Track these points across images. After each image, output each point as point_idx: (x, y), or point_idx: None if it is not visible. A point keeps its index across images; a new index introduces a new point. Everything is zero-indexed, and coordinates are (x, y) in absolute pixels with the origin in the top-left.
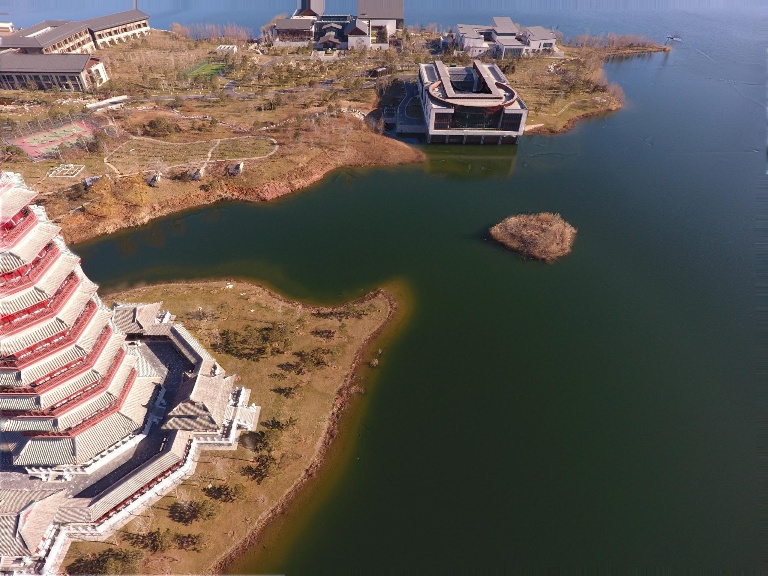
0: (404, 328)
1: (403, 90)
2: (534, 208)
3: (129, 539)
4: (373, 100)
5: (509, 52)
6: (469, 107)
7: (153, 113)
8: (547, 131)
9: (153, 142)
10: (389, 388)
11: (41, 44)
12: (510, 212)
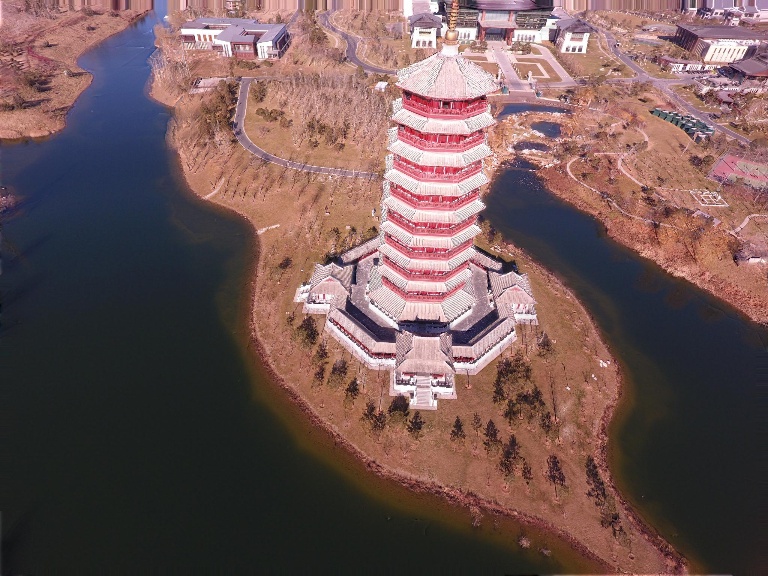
0: None
1: None
2: None
3: None
4: None
5: None
6: None
7: None
8: None
9: None
10: (491, 566)
11: None
12: None
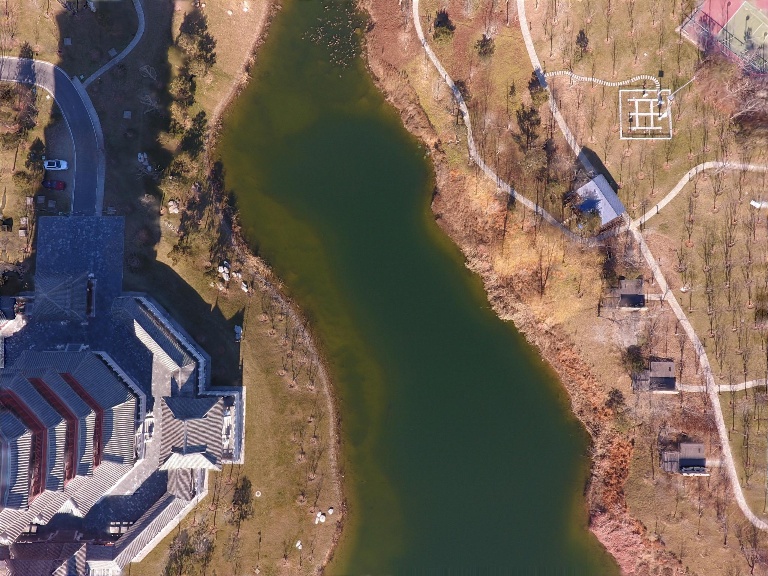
0: None
1: None
2: None
3: None
4: None
5: None
6: None
7: None
8: None
9: None
10: None
11: None
12: None
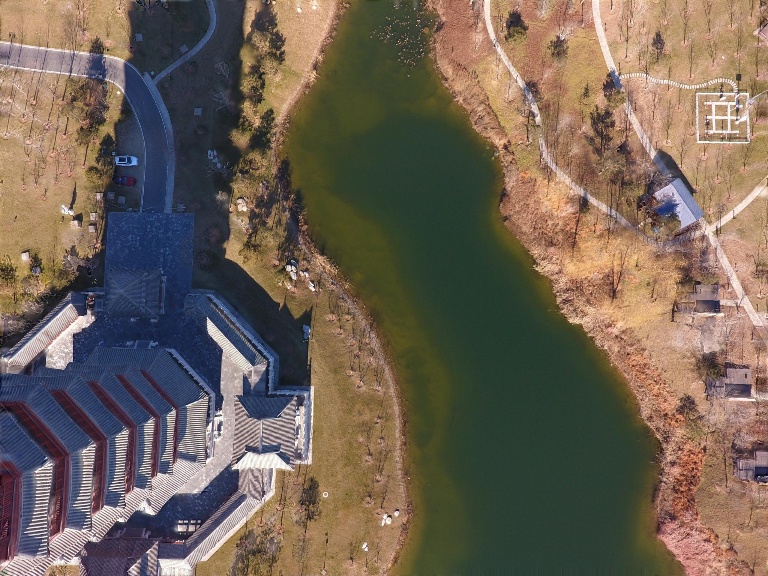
0: None
1: None
2: None
3: None
4: None
5: None
6: None
7: None
8: None
9: None
10: None
11: None
12: None
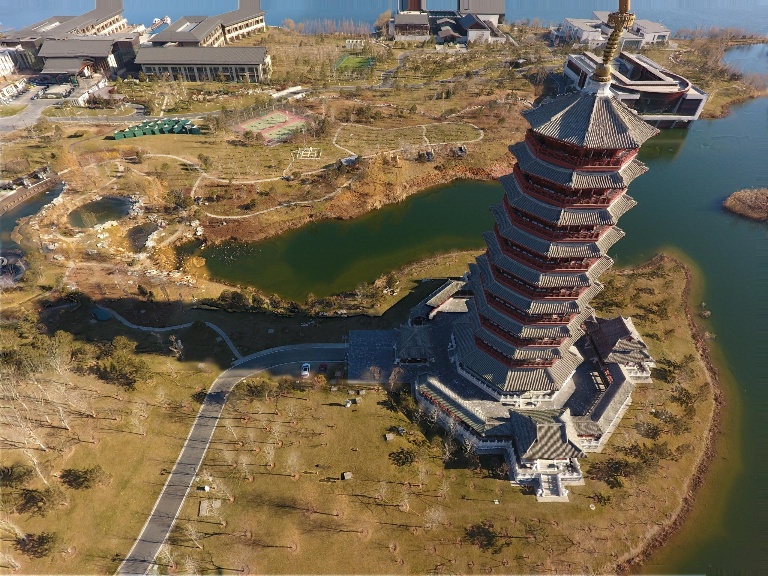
0: (706, 286)
1: (553, 80)
2: (753, 184)
3: (620, 451)
4: (534, 89)
5: (628, 44)
6: (654, 93)
7: (340, 102)
8: (708, 116)
9: (365, 128)
10: (727, 335)
11: (198, 38)
12: (730, 188)
